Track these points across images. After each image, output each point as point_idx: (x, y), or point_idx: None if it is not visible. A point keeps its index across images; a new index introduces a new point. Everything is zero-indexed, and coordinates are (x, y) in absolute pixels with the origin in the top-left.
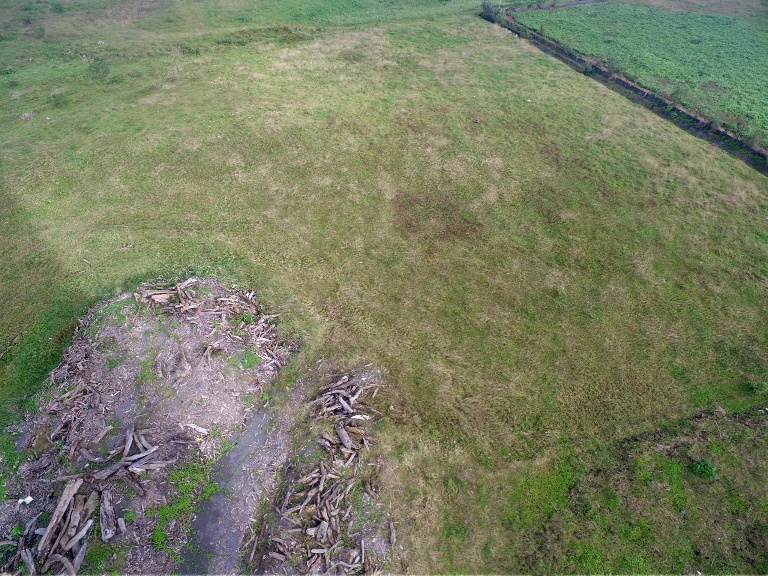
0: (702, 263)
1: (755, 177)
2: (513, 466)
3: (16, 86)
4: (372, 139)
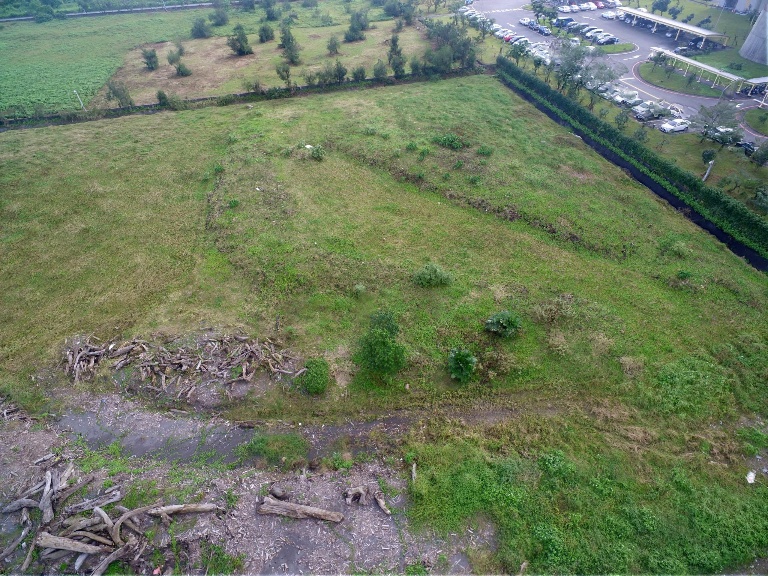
0: (117, 168)
1: (70, 127)
2: (195, 272)
3: None
4: None
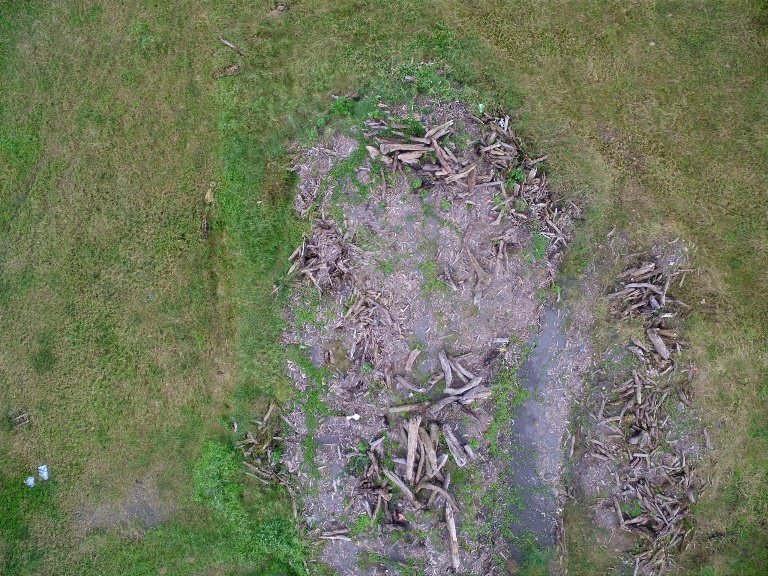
0: None
1: None
2: None
3: None
4: None
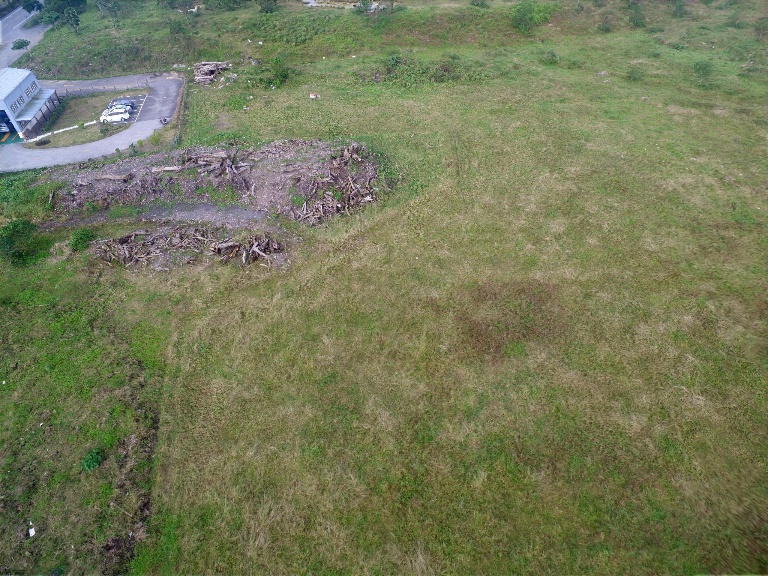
0: None
1: None
2: None
3: (654, 57)
4: (693, 263)
